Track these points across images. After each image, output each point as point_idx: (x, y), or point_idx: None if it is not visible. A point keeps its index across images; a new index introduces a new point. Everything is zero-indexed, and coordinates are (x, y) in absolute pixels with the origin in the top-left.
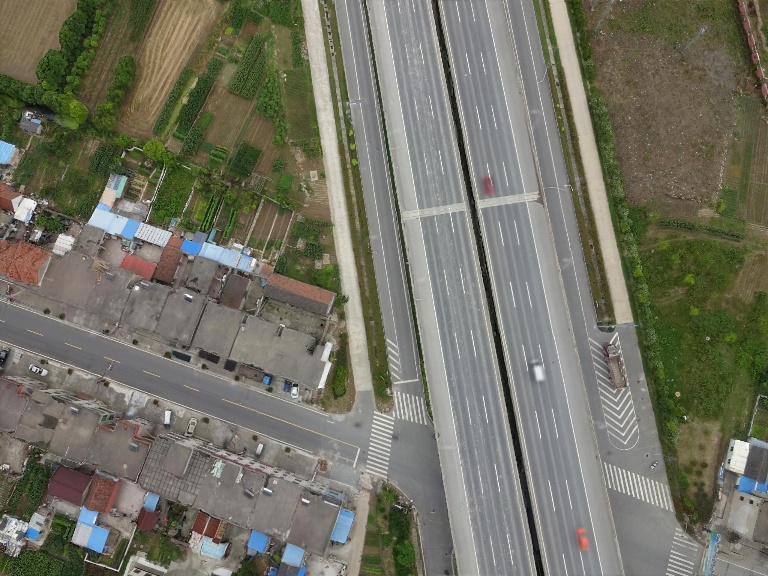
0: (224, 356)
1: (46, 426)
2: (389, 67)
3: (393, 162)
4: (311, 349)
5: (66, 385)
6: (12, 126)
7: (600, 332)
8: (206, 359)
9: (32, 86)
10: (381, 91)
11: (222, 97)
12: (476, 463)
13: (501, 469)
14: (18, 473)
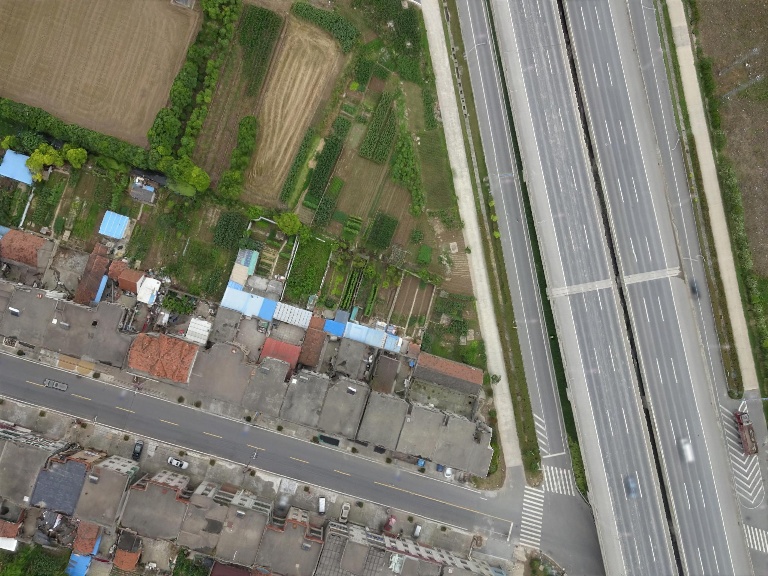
0: (391, 449)
1: (210, 531)
2: (529, 134)
3: (540, 237)
4: (476, 436)
5: (209, 476)
6: (121, 194)
7: (730, 399)
8: (355, 442)
9: (143, 149)
10: (524, 161)
11: (352, 161)
12: (632, 536)
13: (655, 540)
14: (166, 571)
